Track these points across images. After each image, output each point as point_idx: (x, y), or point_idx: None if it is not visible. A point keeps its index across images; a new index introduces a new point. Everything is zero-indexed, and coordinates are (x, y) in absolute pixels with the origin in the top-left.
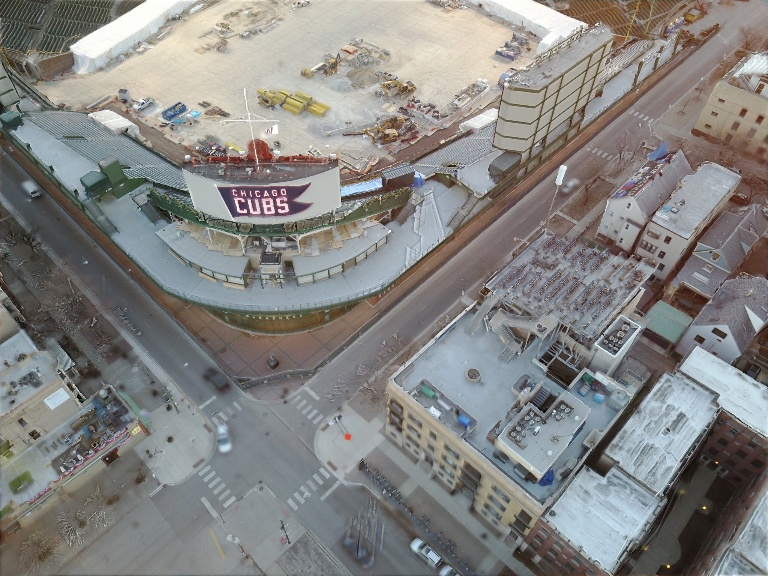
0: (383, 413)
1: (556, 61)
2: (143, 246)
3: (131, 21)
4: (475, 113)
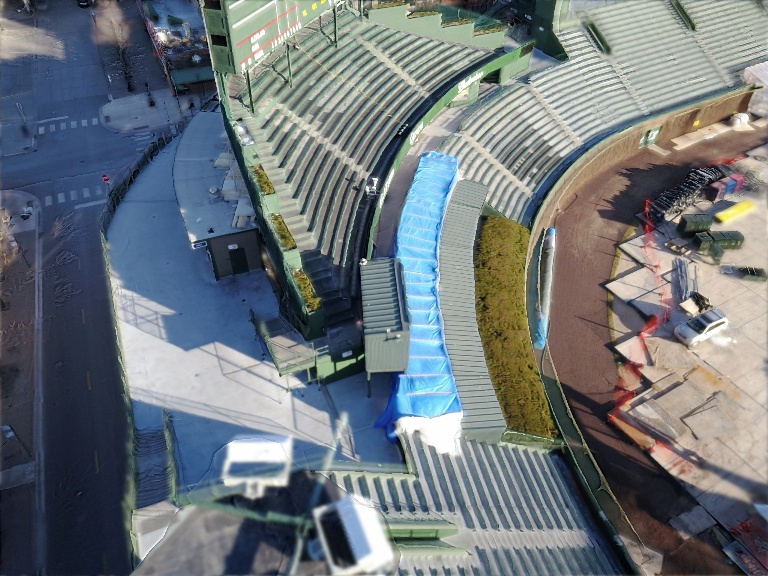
0: None
1: None
2: None
3: None
4: None
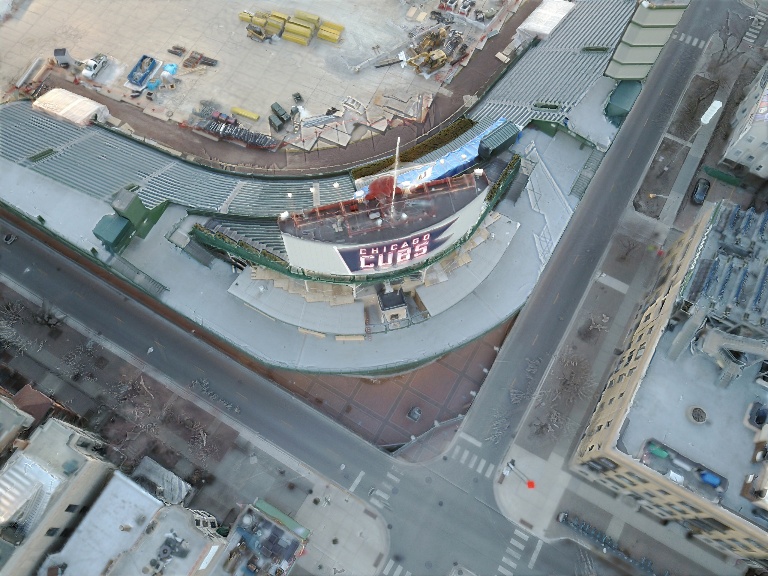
0: (559, 445)
1: None
2: (209, 304)
3: None
4: (524, 4)
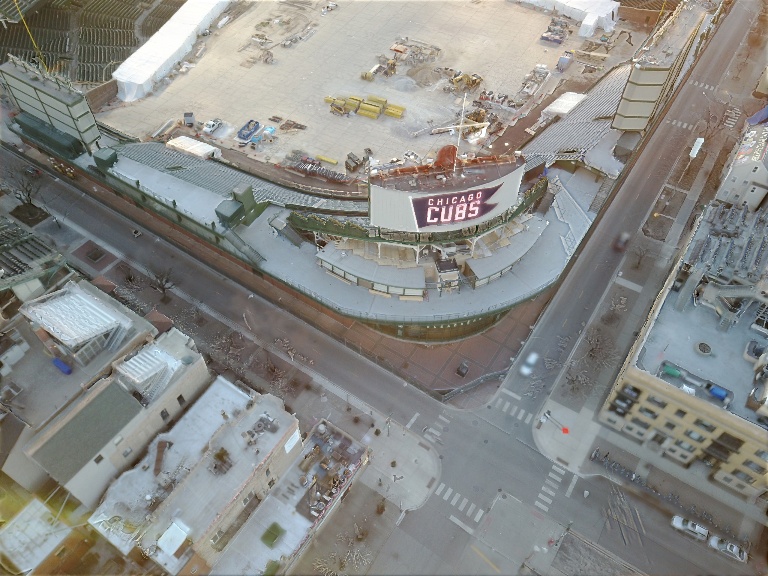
0: (589, 402)
1: (668, 38)
2: (298, 271)
3: (165, 41)
4: (546, 99)
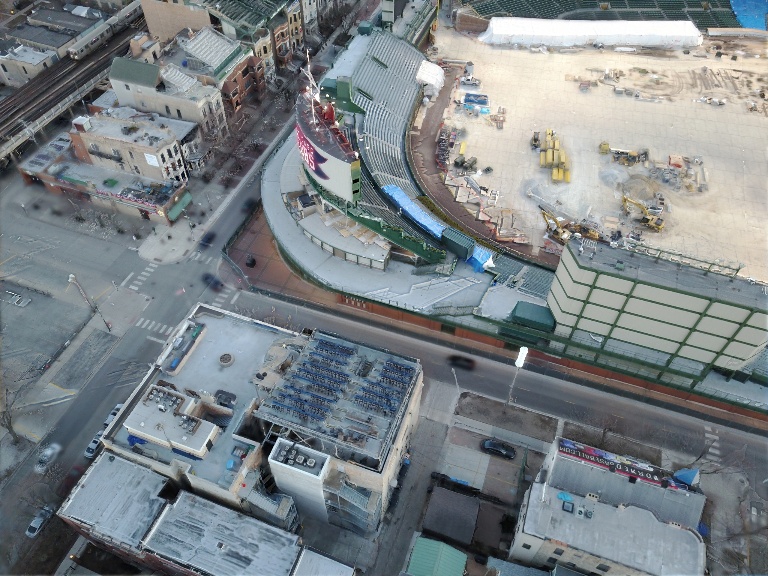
0: None
1: (660, 268)
2: None
3: (558, 26)
4: None
